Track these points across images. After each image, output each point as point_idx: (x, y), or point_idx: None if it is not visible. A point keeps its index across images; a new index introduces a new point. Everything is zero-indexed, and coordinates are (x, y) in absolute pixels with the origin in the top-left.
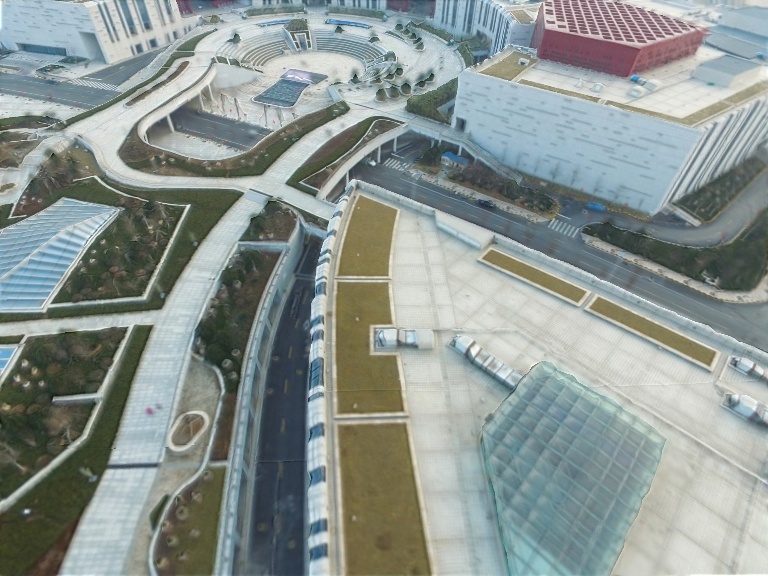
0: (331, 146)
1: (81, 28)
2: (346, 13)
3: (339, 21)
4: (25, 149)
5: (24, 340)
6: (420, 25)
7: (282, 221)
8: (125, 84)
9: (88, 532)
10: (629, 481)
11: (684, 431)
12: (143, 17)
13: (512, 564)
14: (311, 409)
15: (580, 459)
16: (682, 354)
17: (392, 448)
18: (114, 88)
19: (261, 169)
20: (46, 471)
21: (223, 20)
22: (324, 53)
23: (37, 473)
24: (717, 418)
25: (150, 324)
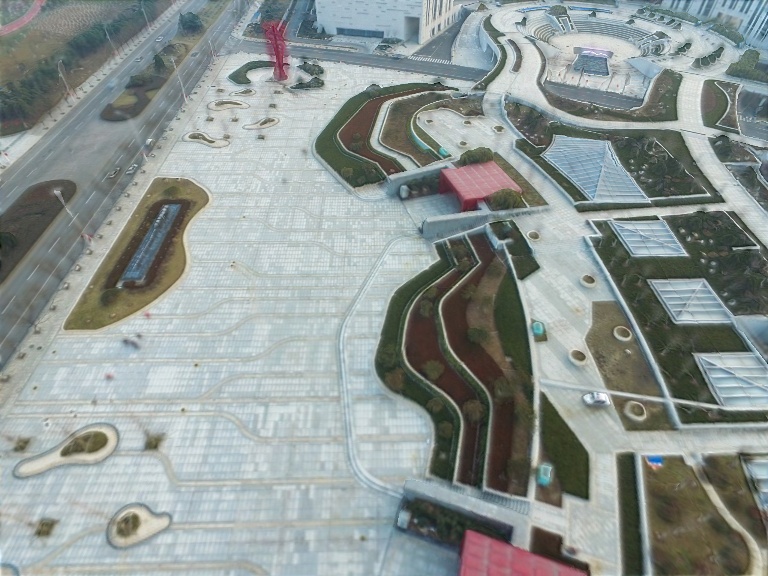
0: (709, 100)
1: (409, 13)
2: (579, 1)
3: (580, 8)
4: (477, 103)
5: (661, 218)
6: (657, 10)
7: (738, 150)
8: (454, 59)
9: None
10: None
11: None
12: (440, 5)
13: None
14: None
15: None
16: None
17: None
18: (450, 63)
19: (674, 116)
20: None
21: (487, 8)
22: (585, 34)
23: None
24: None
25: (731, 211)
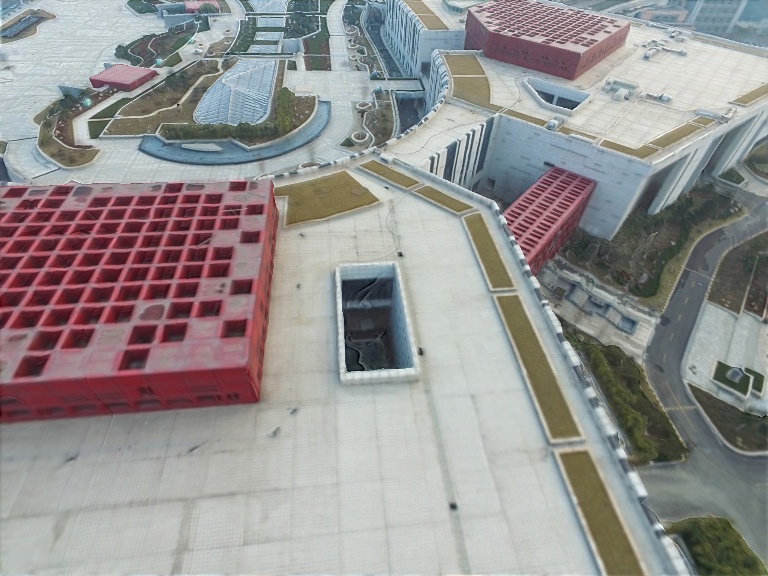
0: None
1: None
2: None
3: None
4: None
5: (285, 17)
6: None
7: None
8: None
9: (333, 41)
10: None
11: None
12: None
13: (449, 3)
14: None
15: None
16: None
17: (420, 3)
18: None
19: None
20: (314, 34)
21: None
22: None
23: (311, 33)
24: None
25: (325, 17)
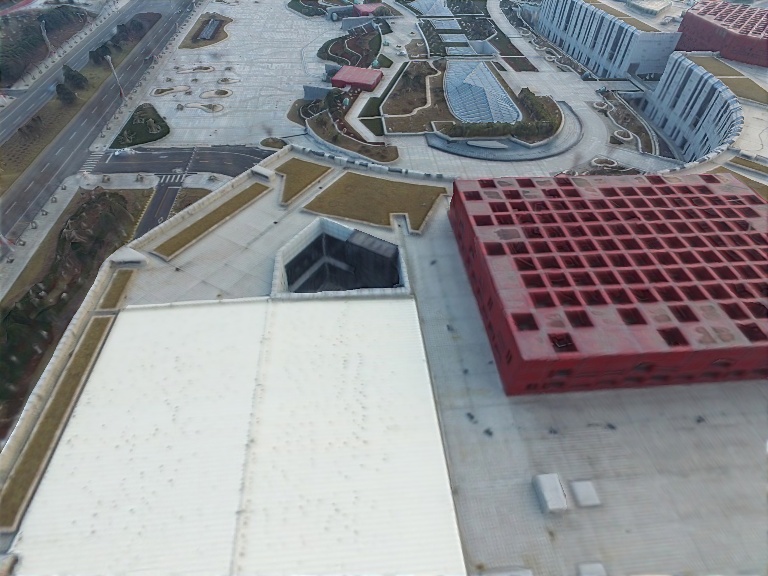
0: None
1: None
2: None
3: None
4: None
5: None
6: None
7: None
8: None
9: None
10: (664, 3)
11: (676, 6)
12: None
13: None
14: (579, 2)
15: (652, 1)
16: (675, 0)
17: None
18: None
19: None
20: None
21: None
22: None
23: (492, 35)
24: (685, 6)
25: (491, 19)
